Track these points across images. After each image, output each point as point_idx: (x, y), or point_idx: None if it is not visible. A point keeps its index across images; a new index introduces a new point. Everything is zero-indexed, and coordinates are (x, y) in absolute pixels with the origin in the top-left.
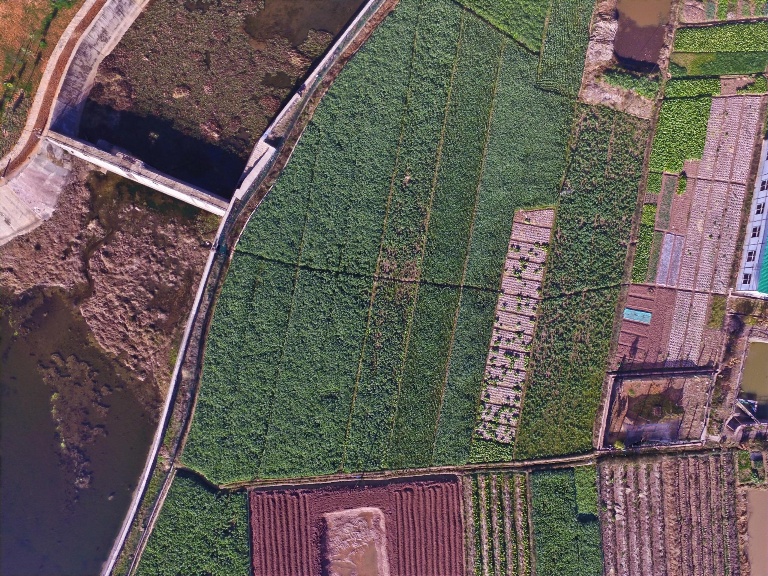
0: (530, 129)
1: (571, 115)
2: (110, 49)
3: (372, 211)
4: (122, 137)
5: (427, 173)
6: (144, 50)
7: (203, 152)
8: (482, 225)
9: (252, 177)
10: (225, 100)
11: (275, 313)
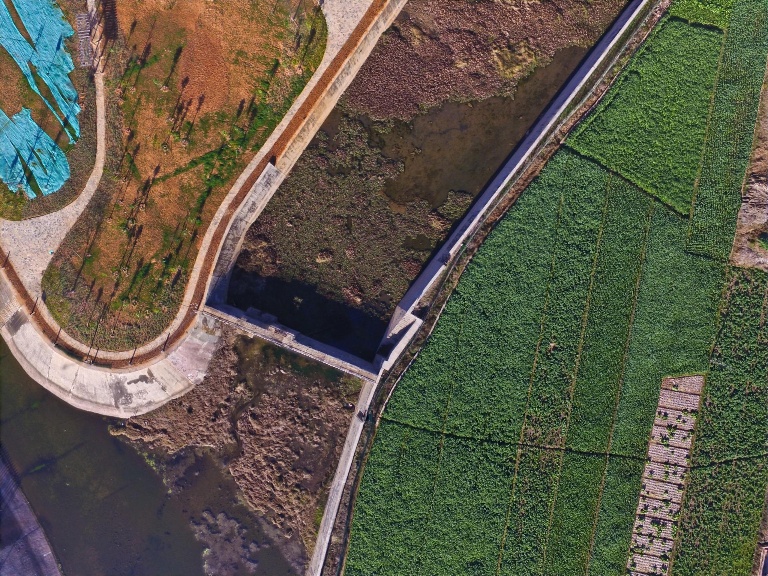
0: (680, 296)
1: (722, 280)
2: (256, 216)
3: (518, 380)
4: (268, 302)
5: (573, 340)
6: (288, 216)
7: (345, 315)
8: (629, 393)
9: (400, 349)
10: (366, 264)
11: (422, 481)
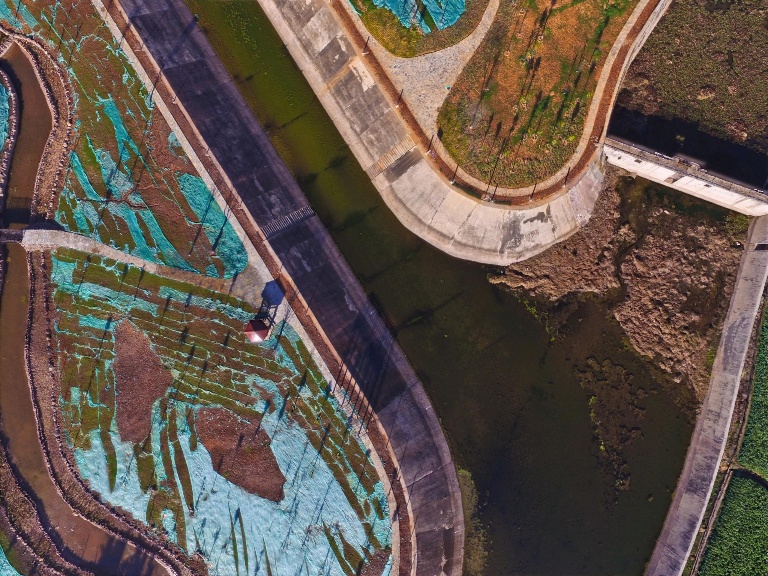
0: None
1: None
2: None
3: None
4: (649, 141)
5: None
6: (667, 53)
7: (730, 153)
8: None
9: None
10: (749, 99)
11: None
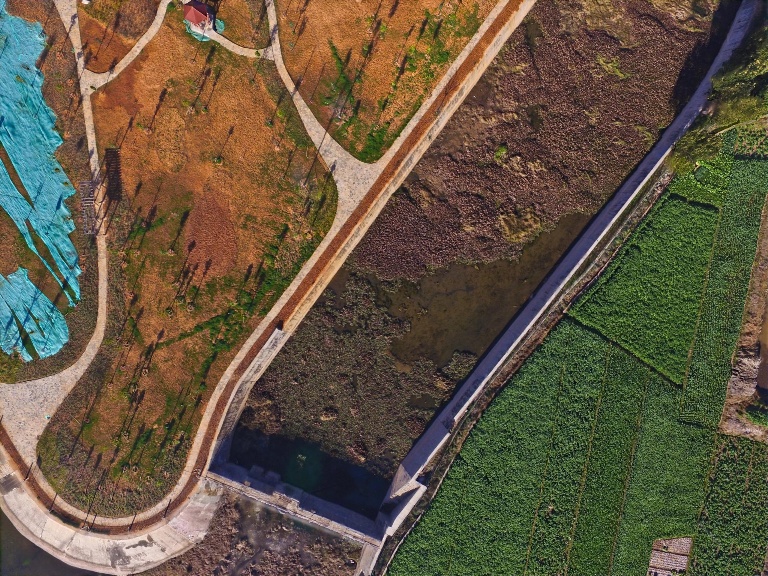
0: (672, 463)
1: (712, 447)
2: (261, 374)
3: (517, 544)
4: (271, 459)
5: (570, 504)
6: (293, 373)
7: (349, 473)
8: (623, 556)
9: (404, 515)
10: (371, 422)
11: None
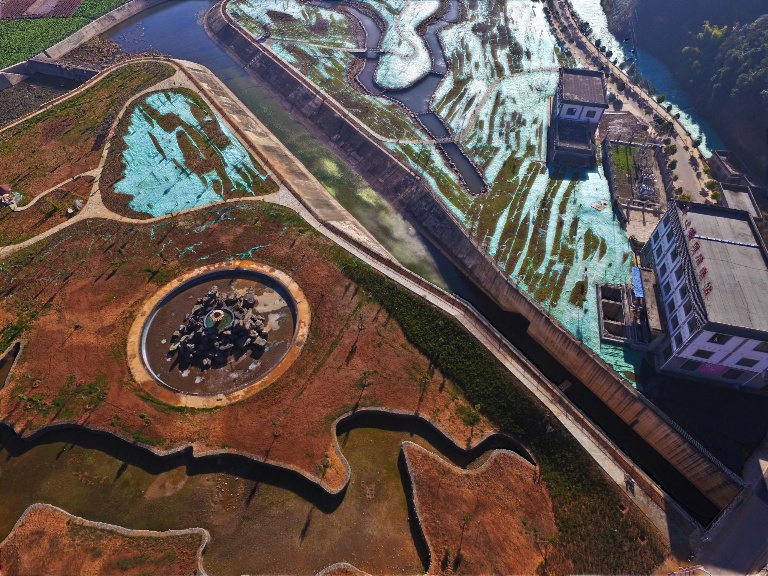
0: None
1: None
2: None
3: None
4: None
5: None
6: None
7: None
8: None
9: (14, 65)
10: None
11: None
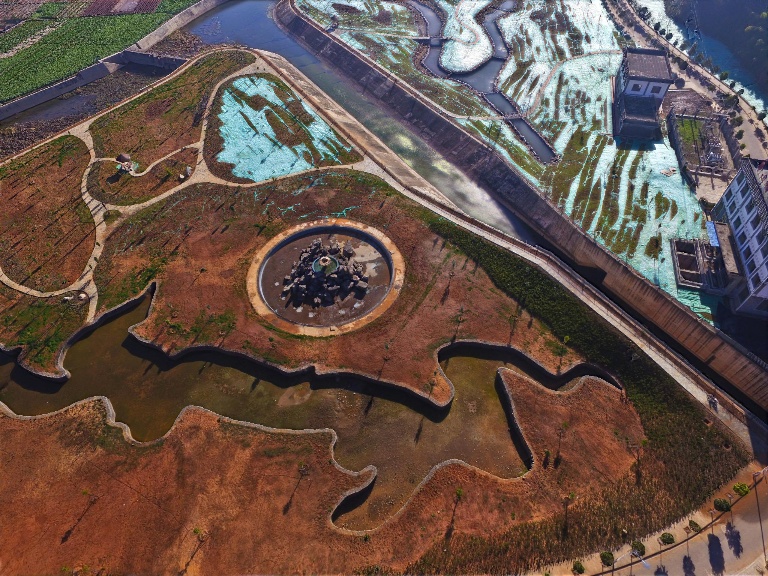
0: None
1: None
2: None
3: None
4: None
5: None
6: None
7: None
8: None
9: None
10: None
11: None
